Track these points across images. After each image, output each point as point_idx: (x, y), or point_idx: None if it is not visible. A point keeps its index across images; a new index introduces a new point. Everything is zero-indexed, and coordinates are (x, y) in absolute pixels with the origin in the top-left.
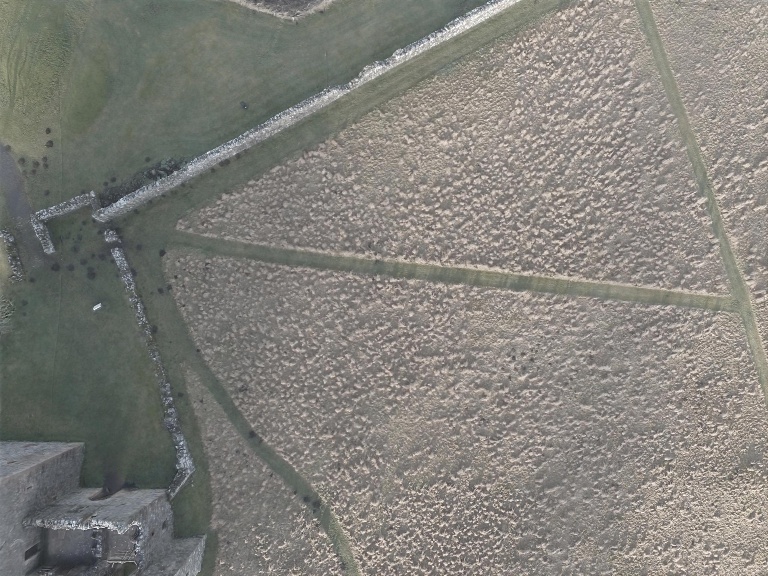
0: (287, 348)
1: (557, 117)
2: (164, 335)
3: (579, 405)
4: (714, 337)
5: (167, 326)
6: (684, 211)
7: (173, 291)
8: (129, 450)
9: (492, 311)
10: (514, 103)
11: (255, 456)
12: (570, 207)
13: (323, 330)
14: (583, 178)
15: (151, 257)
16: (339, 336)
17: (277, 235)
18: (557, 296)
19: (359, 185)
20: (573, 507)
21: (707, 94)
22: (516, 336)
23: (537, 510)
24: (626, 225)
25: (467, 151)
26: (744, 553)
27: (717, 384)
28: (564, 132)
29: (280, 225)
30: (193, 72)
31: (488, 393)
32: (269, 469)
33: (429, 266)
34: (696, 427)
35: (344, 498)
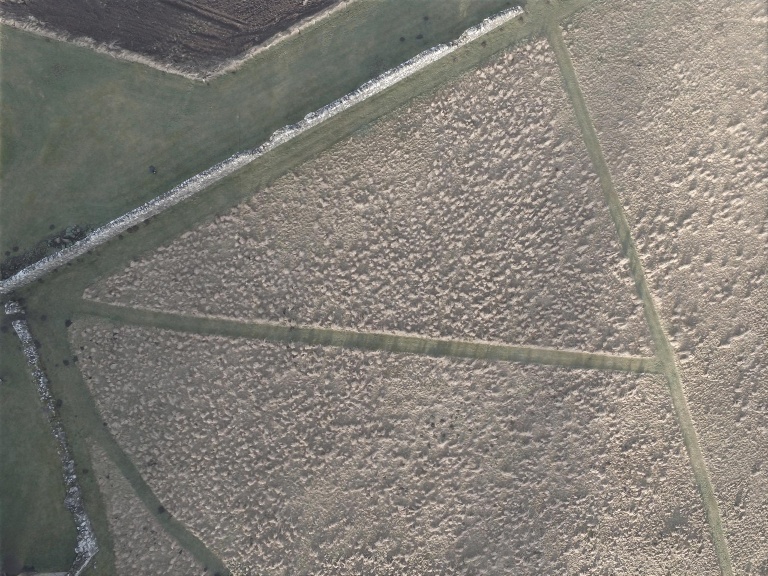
0: (198, 420)
1: (476, 178)
2: (69, 409)
3: (500, 472)
4: (638, 399)
5: (72, 399)
6: (606, 272)
7: (79, 363)
8: (28, 532)
9: (410, 378)
10: (432, 164)
11: (163, 533)
12: (489, 270)
13: (236, 400)
14: (503, 240)
15: (56, 328)
16: (252, 406)
17: (188, 303)
18: (477, 361)
19: (273, 250)
20: None
21: (630, 152)
22: (435, 403)
23: None
24: (547, 288)
25: (384, 214)
26: None
27: (641, 447)
28: (483, 193)
29: (191, 293)
30: (100, 136)
31: (406, 462)
32: (178, 546)
33: (345, 332)
34: (620, 491)
35: (257, 574)
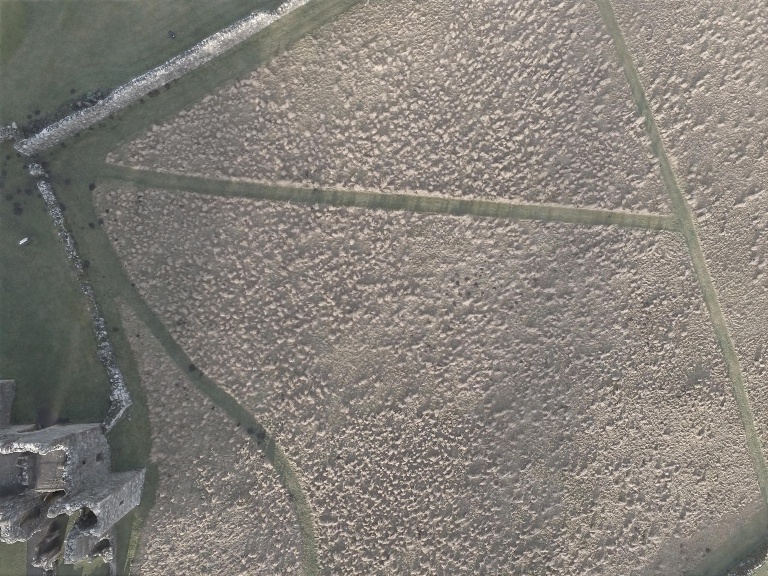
0: (225, 280)
1: (493, 40)
2: (97, 270)
3: (525, 328)
4: (657, 256)
5: (100, 261)
6: (623, 131)
7: (105, 225)
8: (62, 385)
9: (434, 236)
10: (449, 27)
11: (195, 389)
12: (509, 130)
13: (262, 261)
14: (521, 101)
15: (81, 192)
16: (279, 266)
17: (211, 166)
18: (499, 220)
19: (294, 113)
20: (523, 430)
21: (642, 15)
22: (459, 261)
23: (486, 435)
24: (565, 146)
25: (403, 76)
26: (695, 470)
27: (662, 303)
28: (500, 55)
29: (214, 156)
30: (118, 2)
31: (433, 319)
32: (210, 402)
33: (368, 193)
34: (643, 346)
35: (289, 429)
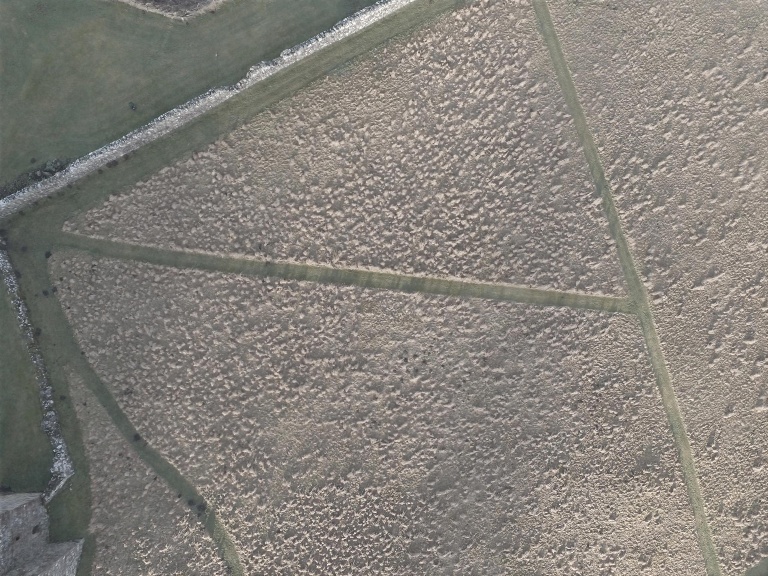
0: (174, 350)
1: (451, 118)
2: (48, 338)
3: (472, 407)
4: (610, 339)
5: (51, 328)
6: (580, 212)
7: (58, 293)
8: (6, 454)
9: (384, 313)
10: (408, 103)
11: (139, 459)
12: (463, 208)
13: (211, 332)
14: (477, 179)
15: (36, 259)
16: (228, 338)
17: (165, 237)
18: (450, 298)
19: (249, 186)
20: (465, 510)
21: (605, 94)
22: (408, 338)
23: (429, 513)
24: (520, 226)
25: (359, 152)
26: (641, 556)
27: (613, 386)
28: (458, 133)
29: (168, 227)
30: (81, 72)
31: (379, 395)
32: (153, 472)
33: (320, 268)
34: (592, 429)
35: (230, 501)
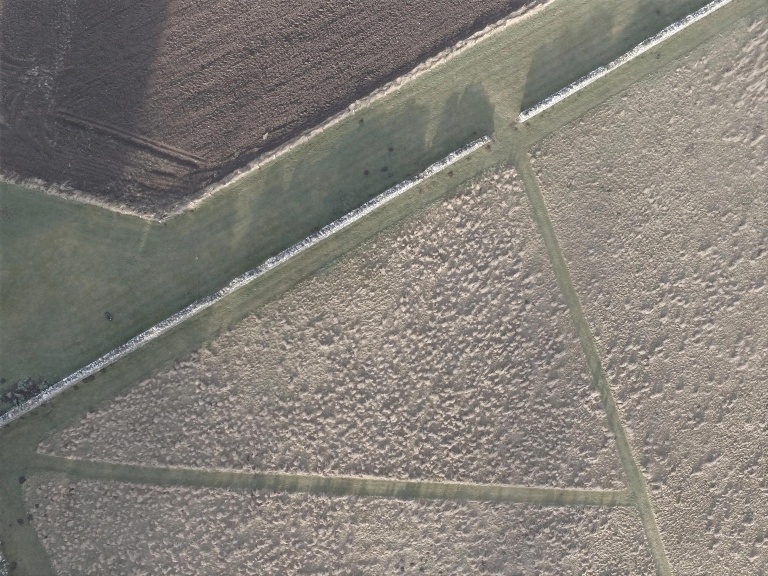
0: (160, 575)
1: (444, 314)
2: (24, 571)
3: None
4: (610, 533)
5: (27, 561)
6: (577, 405)
7: (34, 522)
8: None
9: (378, 522)
10: (399, 300)
11: None
12: (458, 409)
13: (199, 553)
14: (472, 377)
15: (10, 485)
16: (216, 558)
17: (148, 453)
18: (447, 502)
19: (235, 396)
20: None
21: (600, 280)
22: (404, 546)
23: None
24: (517, 424)
25: (350, 354)
26: None
27: None
28: (451, 330)
29: (150, 443)
30: (53, 282)
31: None
32: None
33: (312, 477)
34: None
35: None
